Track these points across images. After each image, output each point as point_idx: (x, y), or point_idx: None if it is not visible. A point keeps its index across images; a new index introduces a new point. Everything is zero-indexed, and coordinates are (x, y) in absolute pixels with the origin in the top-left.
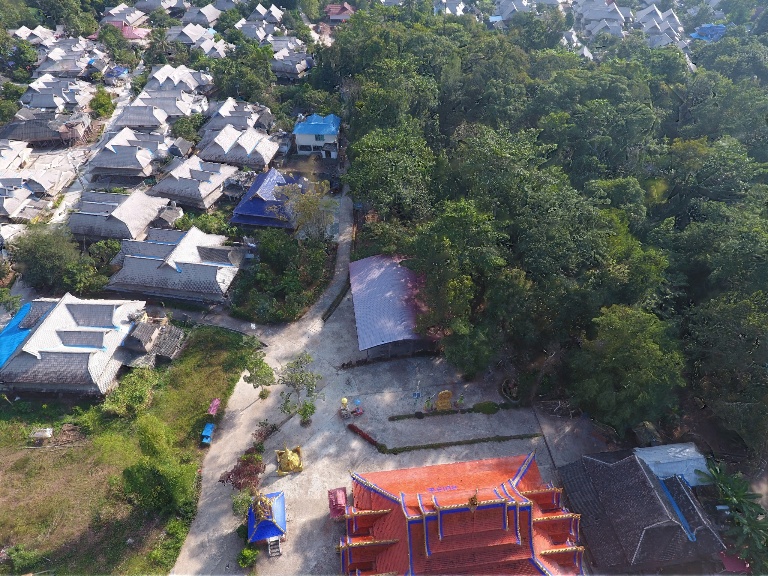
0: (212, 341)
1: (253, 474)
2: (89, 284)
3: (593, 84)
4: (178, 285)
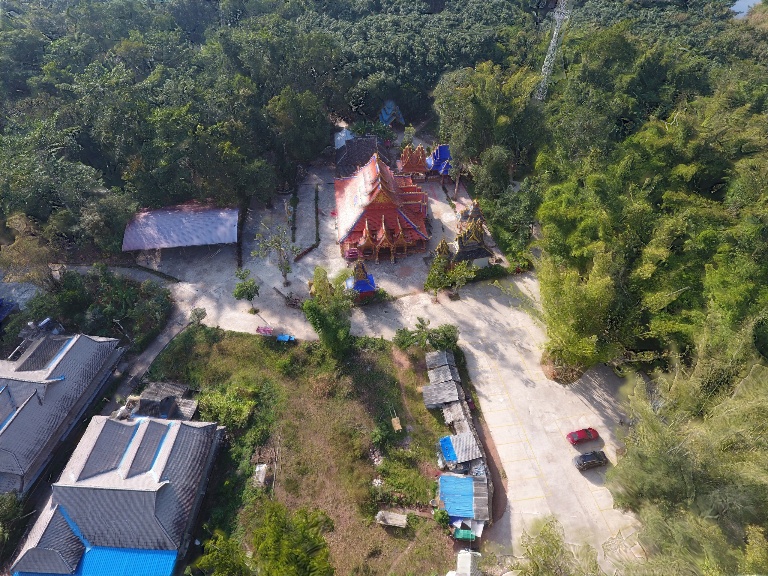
0: None
1: None
2: (1, 521)
3: (18, 40)
4: (81, 386)
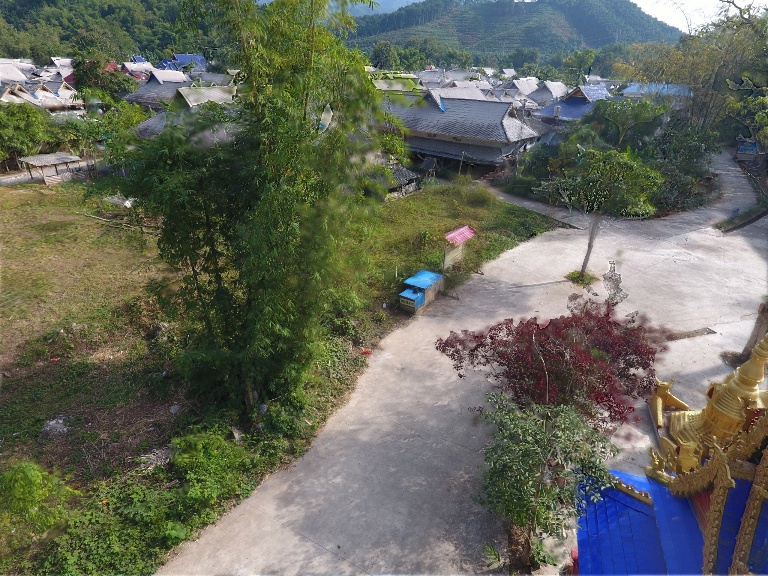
0: None
1: (611, 363)
2: None
3: None
4: (433, 128)
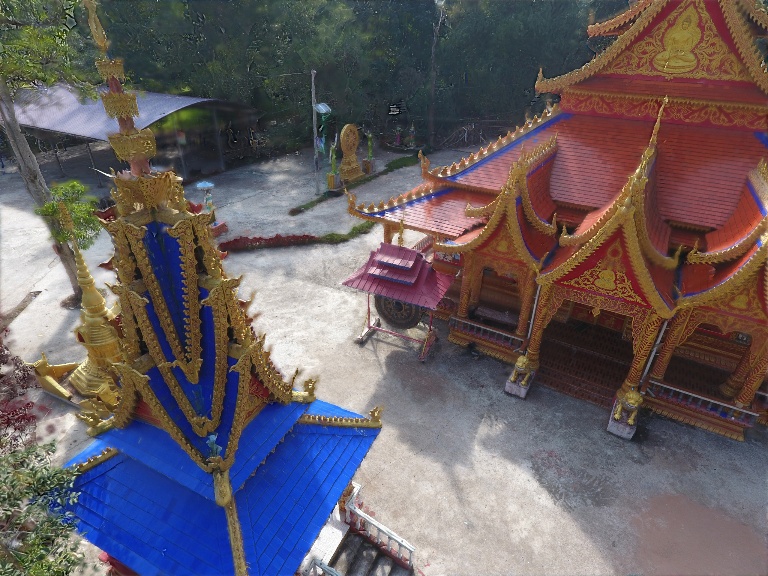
0: None
1: None
2: None
3: None
4: None
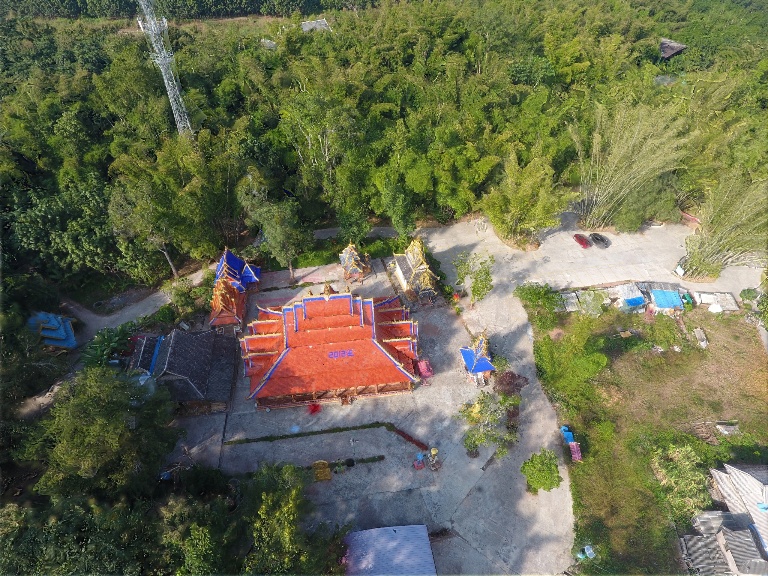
0: (648, 571)
1: None
2: None
3: None
4: None
